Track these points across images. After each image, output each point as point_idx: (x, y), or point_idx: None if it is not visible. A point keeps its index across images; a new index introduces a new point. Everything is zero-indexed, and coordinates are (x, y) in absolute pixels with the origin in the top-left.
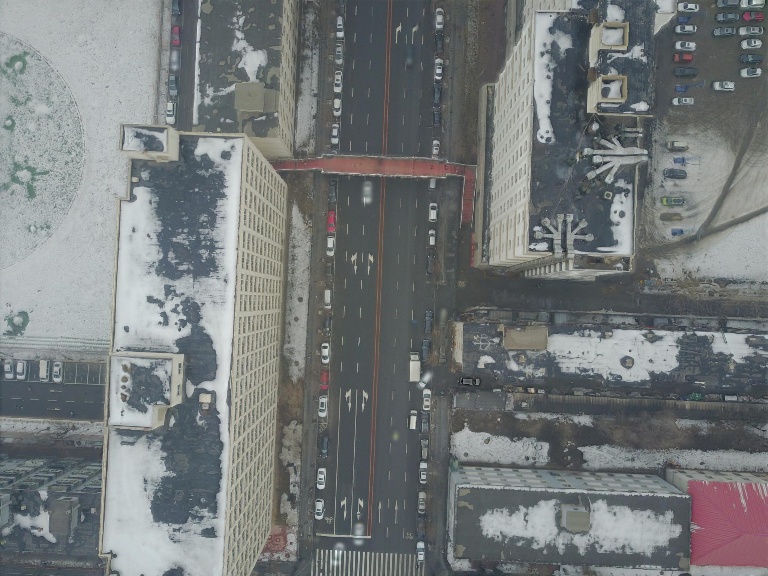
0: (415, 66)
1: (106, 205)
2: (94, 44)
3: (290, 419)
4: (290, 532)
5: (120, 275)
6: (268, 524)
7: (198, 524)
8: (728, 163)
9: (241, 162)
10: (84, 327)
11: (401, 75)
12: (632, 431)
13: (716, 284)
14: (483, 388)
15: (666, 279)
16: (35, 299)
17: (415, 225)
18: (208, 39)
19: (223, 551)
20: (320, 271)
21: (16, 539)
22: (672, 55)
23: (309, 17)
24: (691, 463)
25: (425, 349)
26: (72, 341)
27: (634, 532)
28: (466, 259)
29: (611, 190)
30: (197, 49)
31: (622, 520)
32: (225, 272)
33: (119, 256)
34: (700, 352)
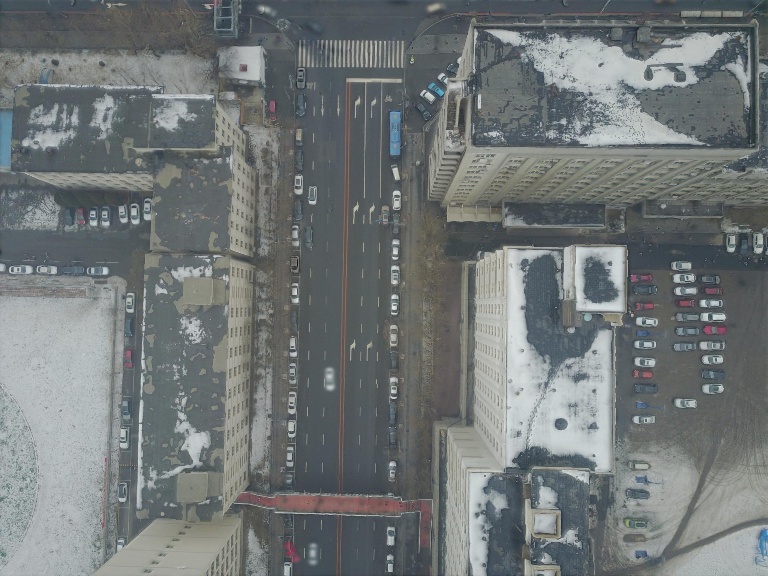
0: (370, 383)
1: (61, 531)
2: (47, 367)
3: None
4: None
5: None
6: None
7: None
8: (692, 482)
9: None
10: None
11: (356, 394)
12: None
13: None
14: None
15: None
16: None
17: (373, 548)
18: (150, 421)
19: None
20: None
21: None
22: (632, 371)
23: (262, 335)
24: None
25: None
26: None
27: None
28: None
29: None
30: (140, 431)
31: None
32: None
33: None
34: None
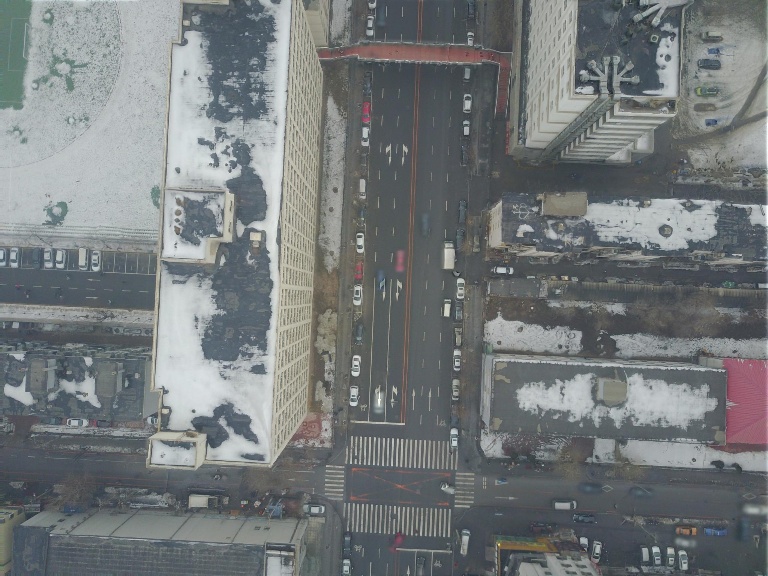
0: None
1: (143, 97)
2: None
3: (325, 308)
4: (325, 419)
5: (171, 117)
6: (305, 406)
7: (248, 361)
8: (762, 54)
9: (291, 5)
10: (122, 217)
11: None
12: (667, 311)
13: (750, 174)
14: (517, 277)
15: (700, 169)
16: (74, 189)
17: (449, 116)
18: None
19: (273, 386)
20: (355, 162)
21: (62, 404)
22: None
23: None
24: (724, 351)
25: (459, 238)
26: (110, 230)
27: (670, 405)
28: (500, 149)
29: (657, 34)
30: None
31: (658, 393)
32: (275, 114)
33: (171, 98)
34: (738, 224)
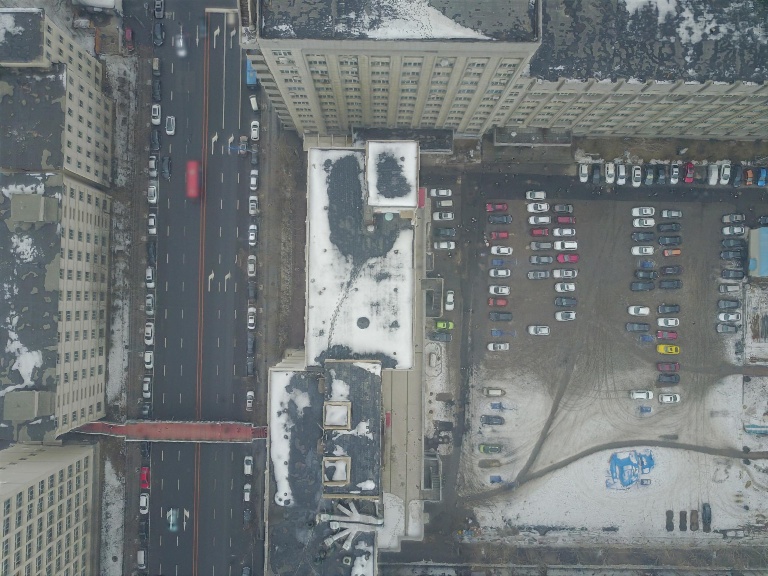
0: (229, 314)
1: None
2: None
3: None
4: None
5: None
6: None
7: None
8: (545, 407)
9: None
10: None
11: (214, 324)
12: None
13: (536, 531)
14: None
15: (486, 527)
16: None
17: (231, 478)
18: None
19: None
20: (134, 529)
21: None
22: (487, 299)
23: (119, 266)
24: None
25: None
26: None
27: None
28: None
29: (351, 553)
30: None
31: None
32: None
33: None
34: None
